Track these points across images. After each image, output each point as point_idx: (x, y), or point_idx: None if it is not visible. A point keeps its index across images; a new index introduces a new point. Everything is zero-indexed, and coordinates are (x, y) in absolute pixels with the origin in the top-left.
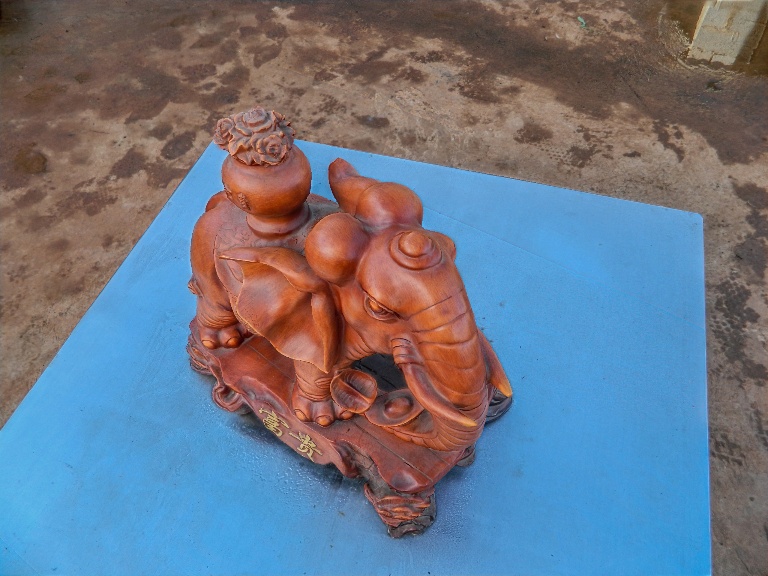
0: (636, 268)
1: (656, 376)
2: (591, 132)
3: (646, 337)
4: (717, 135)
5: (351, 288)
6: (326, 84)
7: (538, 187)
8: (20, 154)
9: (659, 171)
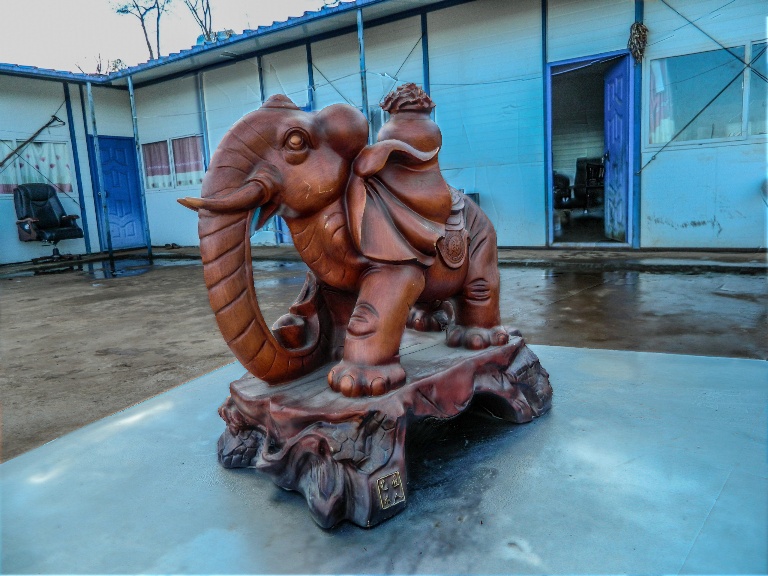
0: None
1: None
2: None
3: None
4: None
5: None
6: None
7: None
8: None
9: None
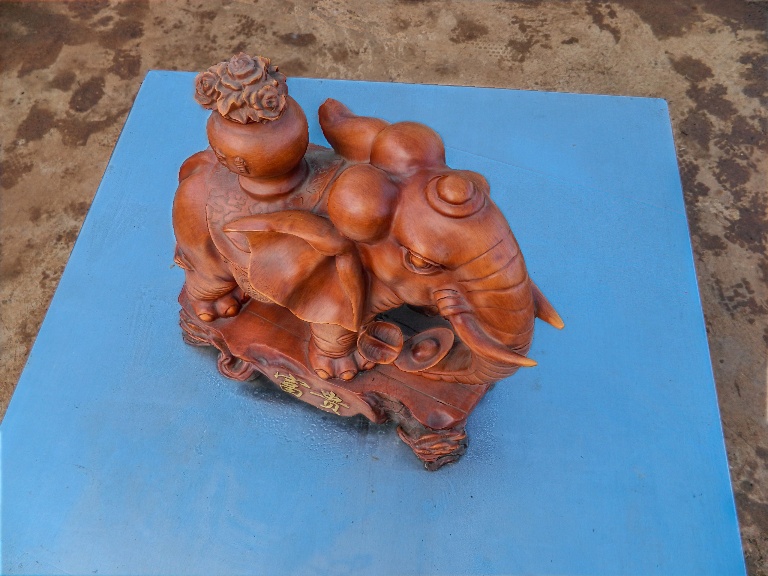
0: (612, 164)
1: (648, 269)
2: (526, 22)
3: (633, 233)
4: (649, 9)
5: (384, 245)
6: (238, 2)
7: (502, 93)
8: None
9: (598, 55)
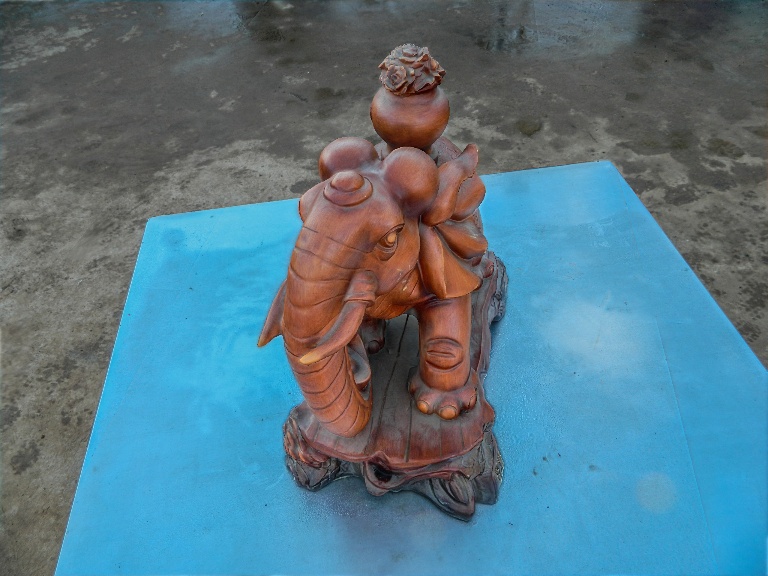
0: None
1: None
2: None
3: None
4: None
5: None
6: None
7: None
8: (531, 116)
9: None
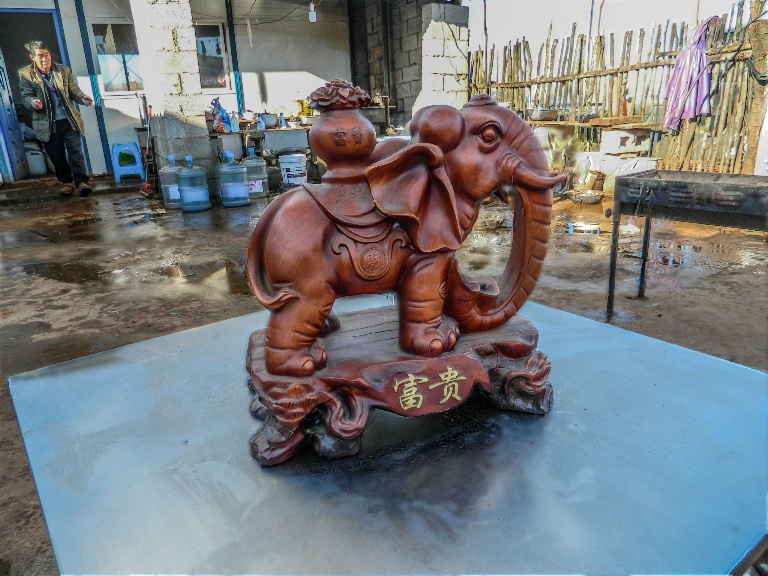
0: None
1: None
2: None
3: None
4: None
5: (464, 142)
6: None
7: None
8: None
9: None
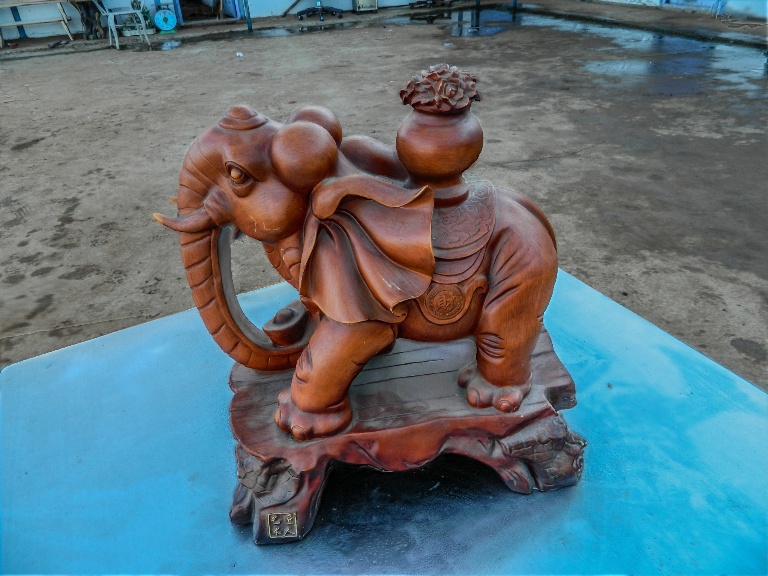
0: None
1: None
2: None
3: None
4: None
5: None
6: None
7: None
8: None
9: None
